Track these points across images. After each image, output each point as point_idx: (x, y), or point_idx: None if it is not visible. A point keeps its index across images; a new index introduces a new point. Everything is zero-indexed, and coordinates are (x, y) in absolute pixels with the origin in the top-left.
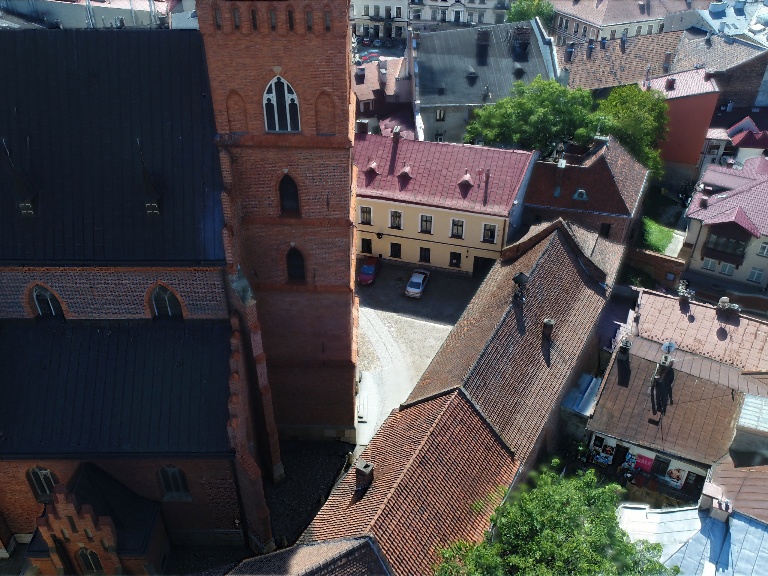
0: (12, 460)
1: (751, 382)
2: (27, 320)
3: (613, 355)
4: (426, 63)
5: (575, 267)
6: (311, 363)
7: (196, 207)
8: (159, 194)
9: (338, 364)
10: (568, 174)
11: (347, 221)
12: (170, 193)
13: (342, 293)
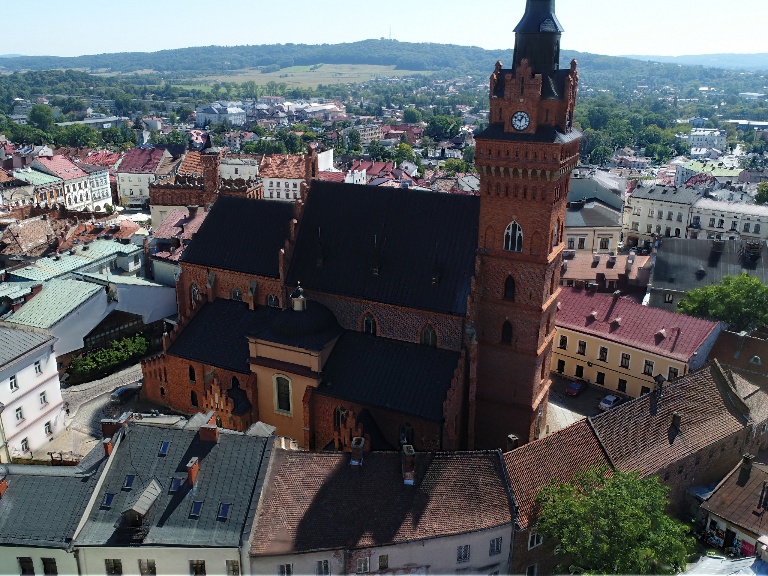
0: (331, 398)
1: None
2: (358, 332)
3: (738, 464)
4: (663, 258)
5: (722, 396)
6: (506, 402)
7: (458, 284)
8: (441, 274)
9: (523, 407)
10: (748, 343)
11: (540, 308)
12: (447, 275)
13: (532, 356)
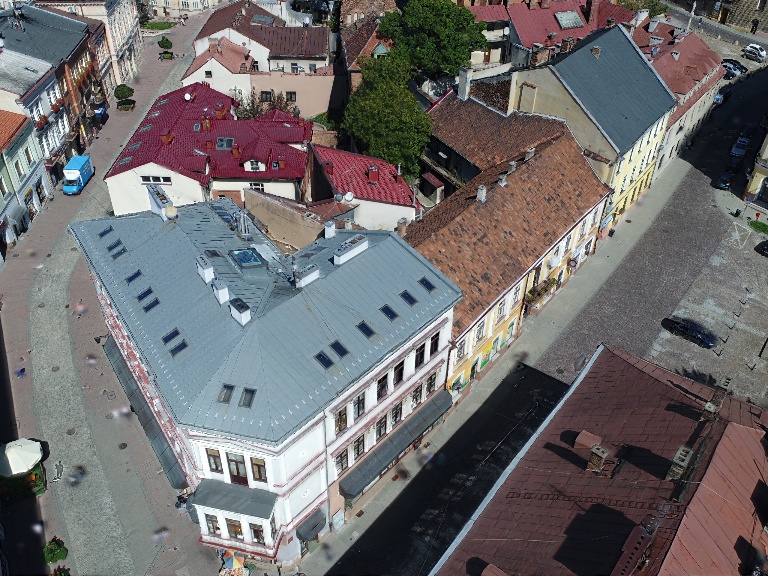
0: None
1: (267, 43)
2: None
3: None
4: None
5: None
6: None
7: None
8: None
9: None
10: None
11: None
12: None
13: None
